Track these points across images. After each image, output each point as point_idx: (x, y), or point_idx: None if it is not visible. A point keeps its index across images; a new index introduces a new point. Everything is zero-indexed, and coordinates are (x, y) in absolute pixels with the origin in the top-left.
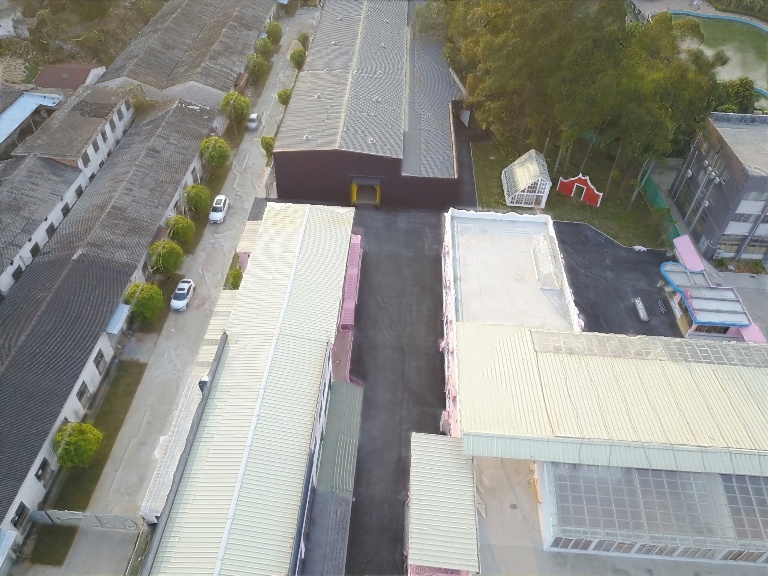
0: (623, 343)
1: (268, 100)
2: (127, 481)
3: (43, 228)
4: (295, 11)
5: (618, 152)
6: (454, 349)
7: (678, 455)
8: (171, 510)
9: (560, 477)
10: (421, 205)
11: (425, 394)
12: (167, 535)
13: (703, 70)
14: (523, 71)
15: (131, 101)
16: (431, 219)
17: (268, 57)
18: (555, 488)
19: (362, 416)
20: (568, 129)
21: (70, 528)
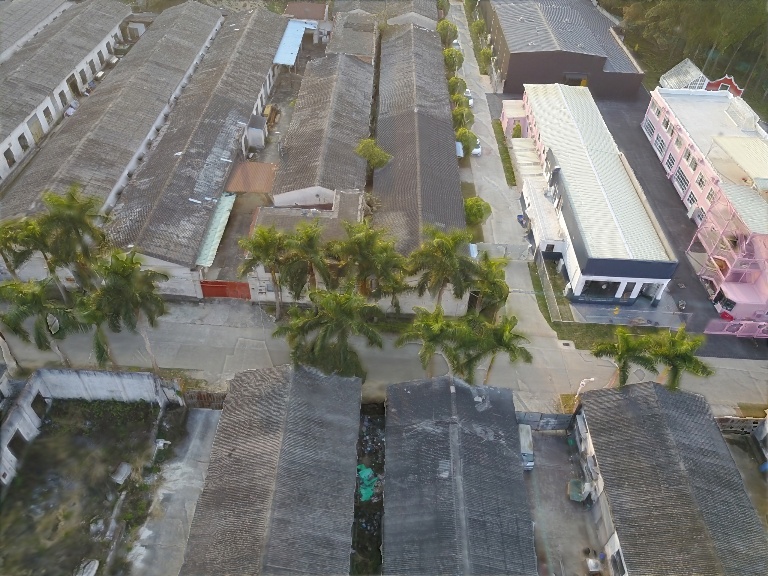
0: None
1: None
2: (503, 239)
3: None
4: None
5: (760, 55)
6: (703, 158)
7: None
8: None
9: None
10: (612, 97)
11: (669, 201)
12: (583, 237)
13: None
14: None
15: (377, 24)
16: (622, 106)
17: None
18: None
19: None
20: (728, 35)
21: None
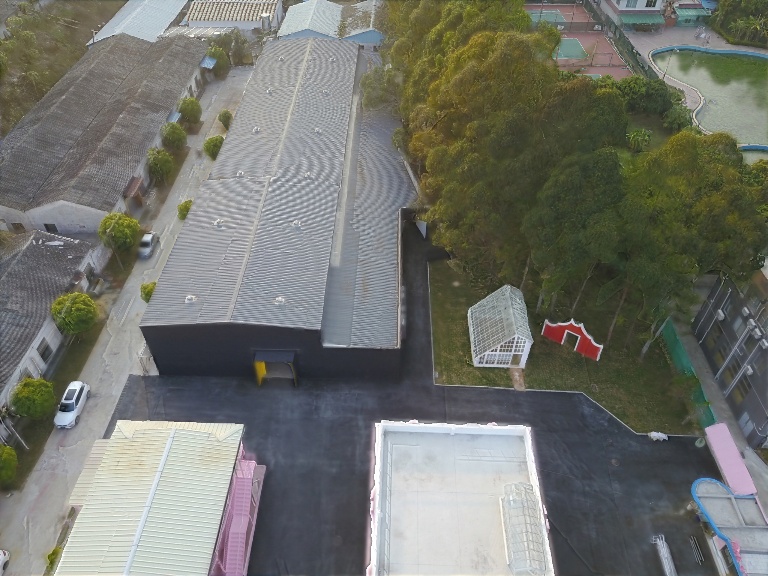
0: None
1: (174, 207)
2: None
3: None
4: (227, 72)
5: (622, 297)
6: None
7: None
8: None
9: None
10: (355, 378)
11: None
12: None
13: (745, 214)
14: (485, 198)
15: None
16: (367, 401)
17: (179, 146)
18: None
19: None
20: (551, 277)
21: None
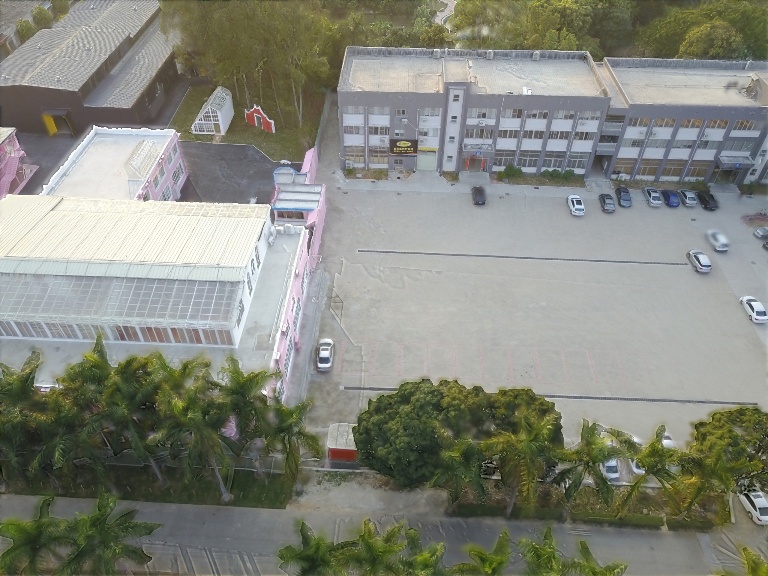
0: (130, 205)
1: None
2: None
3: None
4: None
5: (272, 83)
6: None
7: (91, 266)
8: None
9: None
10: None
11: None
12: None
13: (286, 3)
14: (179, 15)
15: None
16: None
17: (46, 23)
18: None
19: None
20: (218, 62)
21: None
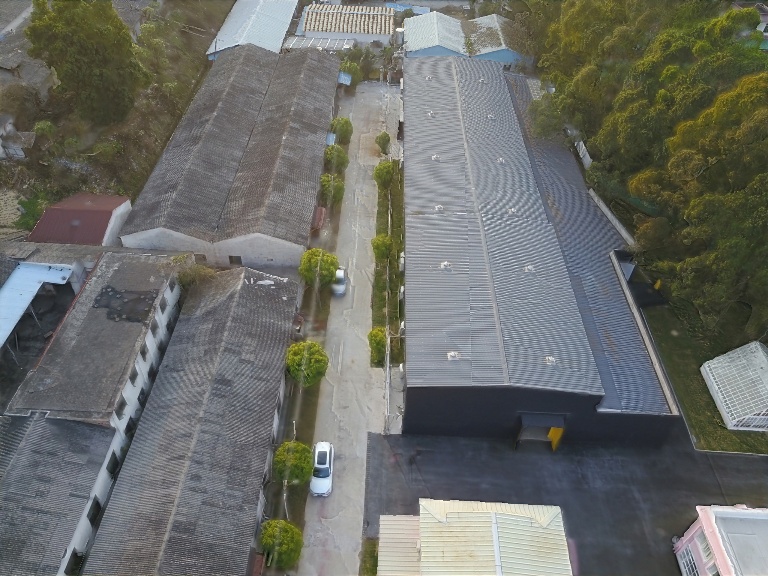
0: None
1: (350, 238)
2: None
3: (60, 571)
4: (355, 87)
5: None
6: None
7: None
8: None
9: None
10: (614, 442)
11: None
12: None
13: None
14: None
15: (176, 276)
16: (634, 469)
17: (341, 170)
18: None
19: None
20: None
21: None
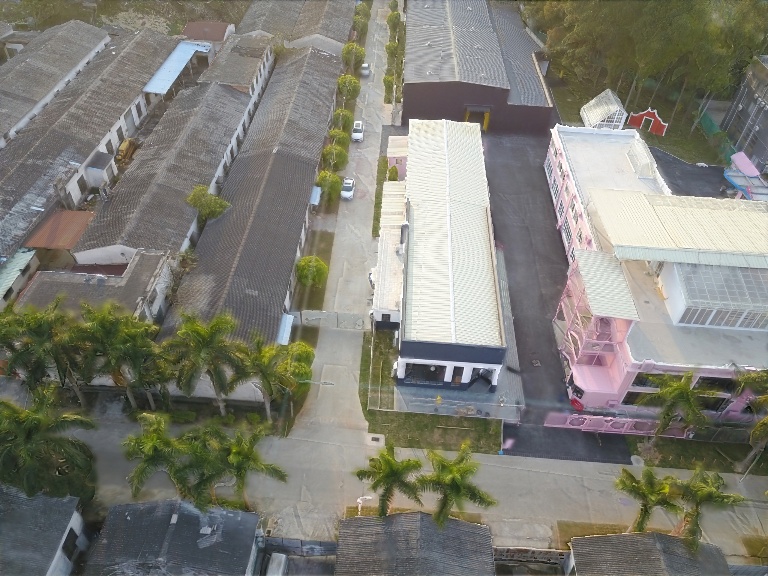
0: (714, 202)
1: (371, 54)
2: (345, 302)
3: (235, 136)
4: None
5: (683, 87)
6: (582, 212)
7: None
8: (406, 298)
9: (686, 272)
10: (520, 131)
11: (551, 256)
12: (409, 311)
13: (761, 12)
14: (608, 19)
15: (273, 48)
16: (530, 141)
17: None
18: (684, 278)
19: (506, 269)
20: (645, 66)
21: (314, 328)
